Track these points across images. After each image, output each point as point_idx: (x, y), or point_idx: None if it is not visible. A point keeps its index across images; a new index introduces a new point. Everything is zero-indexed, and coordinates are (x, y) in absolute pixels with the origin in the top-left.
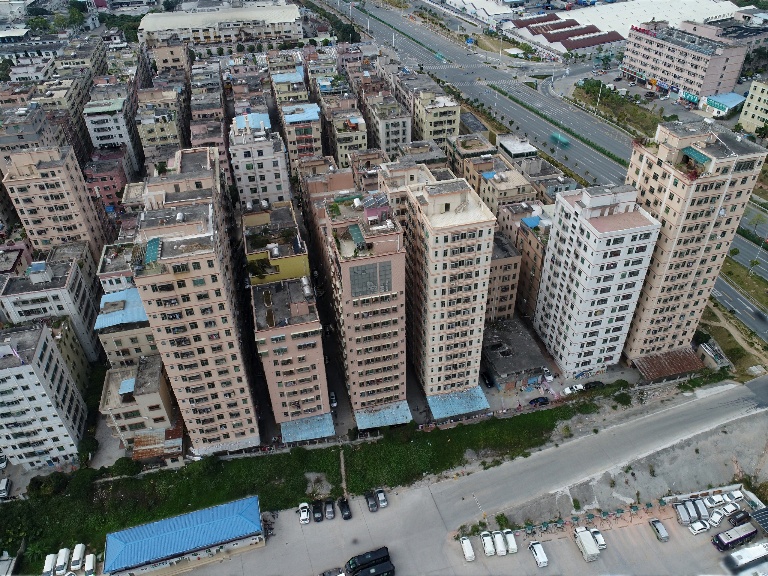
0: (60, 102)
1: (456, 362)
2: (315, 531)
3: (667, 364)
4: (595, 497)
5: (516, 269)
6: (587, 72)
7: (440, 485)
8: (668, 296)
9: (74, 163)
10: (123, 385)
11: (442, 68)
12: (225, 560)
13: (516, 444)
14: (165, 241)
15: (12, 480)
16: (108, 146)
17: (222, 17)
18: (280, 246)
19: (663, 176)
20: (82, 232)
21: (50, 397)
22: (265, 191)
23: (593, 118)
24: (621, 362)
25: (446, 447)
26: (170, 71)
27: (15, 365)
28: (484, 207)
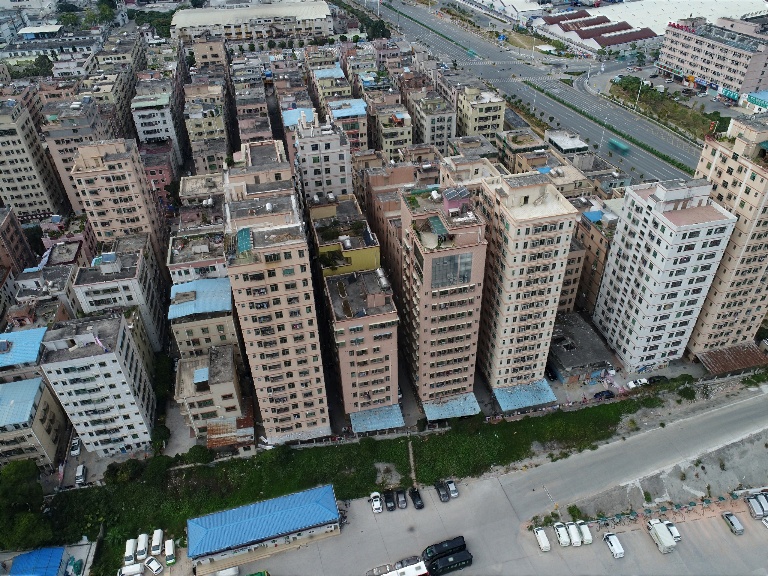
0: (107, 97)
1: (525, 355)
2: (388, 520)
3: (731, 359)
4: (666, 490)
5: (579, 263)
6: (622, 69)
7: (509, 476)
8: (737, 291)
9: (137, 156)
10: (197, 374)
11: (475, 64)
12: (302, 547)
13: (582, 437)
14: (255, 231)
15: (87, 467)
16: (154, 140)
17: (253, 13)
18: (350, 238)
19: (739, 170)
20: (144, 224)
21: (129, 385)
22: (329, 184)
23: (632, 115)
24: (682, 357)
25: (513, 439)
26: (210, 66)
27: (98, 353)
28: (563, 200)
